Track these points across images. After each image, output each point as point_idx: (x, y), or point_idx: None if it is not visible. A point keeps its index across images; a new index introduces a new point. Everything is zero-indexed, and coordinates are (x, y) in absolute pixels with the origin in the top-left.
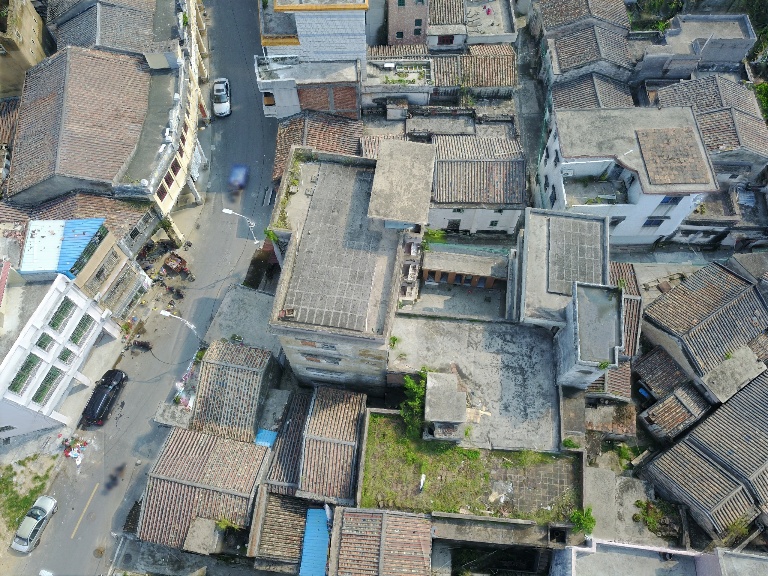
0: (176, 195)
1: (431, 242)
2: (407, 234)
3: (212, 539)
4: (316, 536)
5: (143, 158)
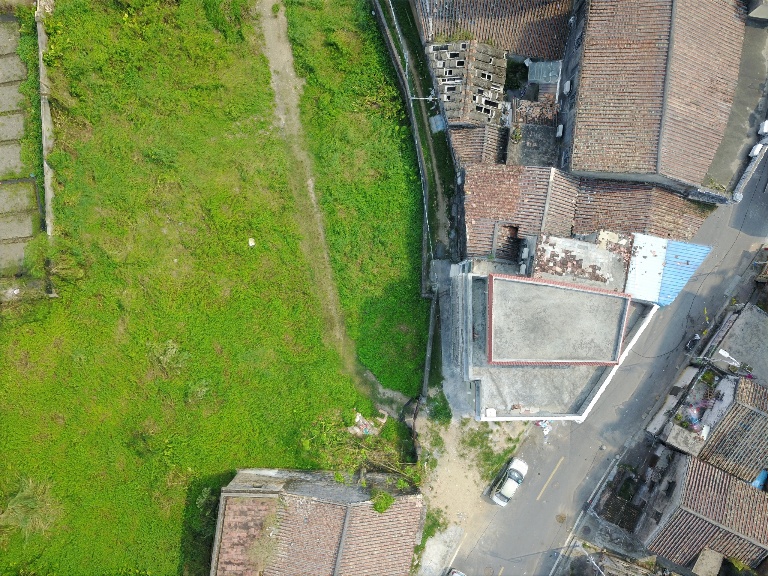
0: None
1: None
2: None
3: None
4: None
5: (724, 152)
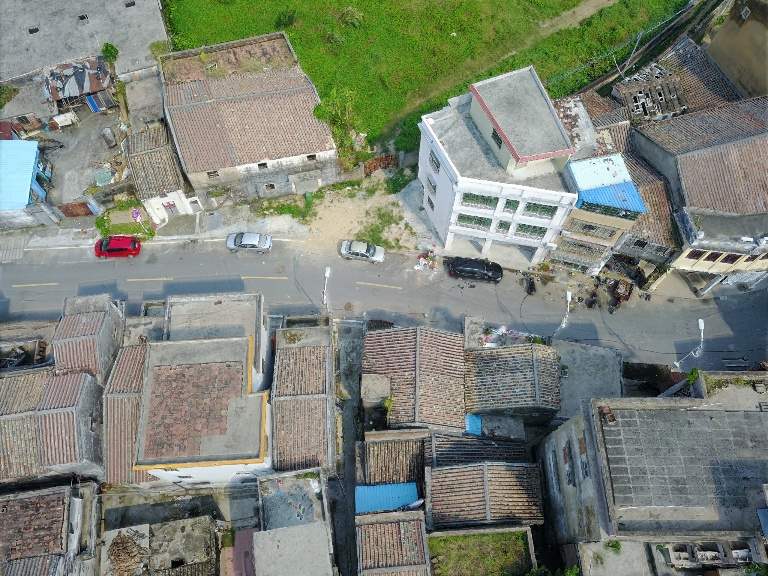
0: (698, 269)
1: (758, 575)
2: (760, 541)
3: (374, 397)
4: (393, 496)
5: (727, 225)
